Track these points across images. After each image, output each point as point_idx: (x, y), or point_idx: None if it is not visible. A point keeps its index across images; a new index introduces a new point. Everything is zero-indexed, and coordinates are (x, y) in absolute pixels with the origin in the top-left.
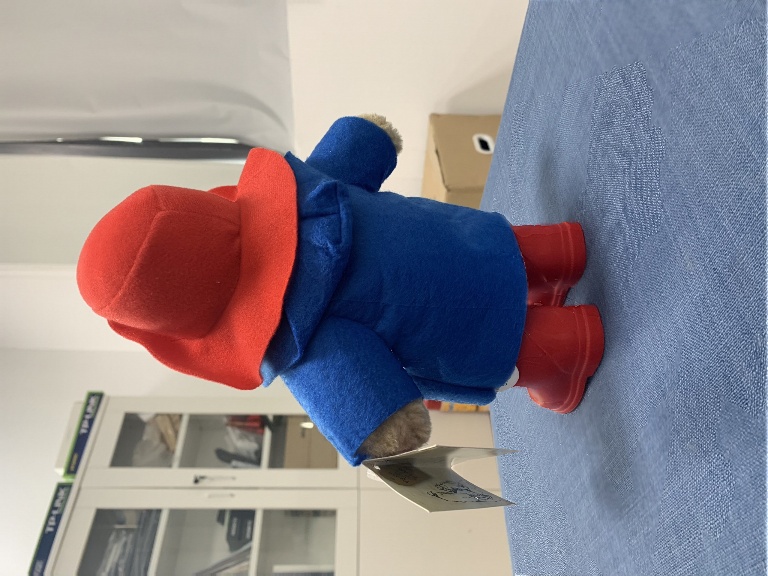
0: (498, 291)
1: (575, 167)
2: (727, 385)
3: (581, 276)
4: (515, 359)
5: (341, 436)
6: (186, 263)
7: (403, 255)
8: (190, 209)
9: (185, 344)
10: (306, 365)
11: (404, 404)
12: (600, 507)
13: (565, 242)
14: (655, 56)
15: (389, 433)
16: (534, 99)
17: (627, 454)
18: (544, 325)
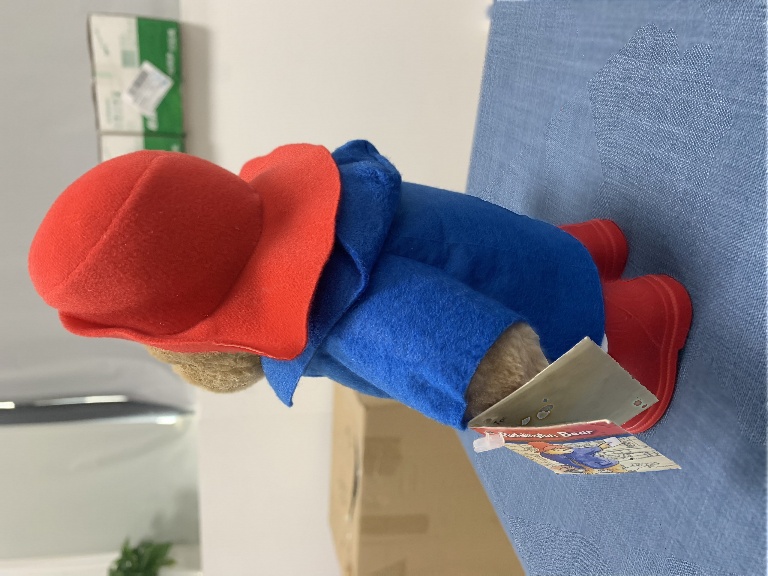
0: (561, 249)
1: (582, 175)
2: None
3: (624, 265)
4: (602, 319)
5: (444, 366)
6: (199, 199)
7: (455, 204)
8: (197, 159)
9: (179, 337)
10: (373, 298)
11: (518, 318)
12: (761, 495)
13: (600, 230)
14: (666, 1)
15: (508, 355)
16: (504, 170)
17: None
18: (616, 291)
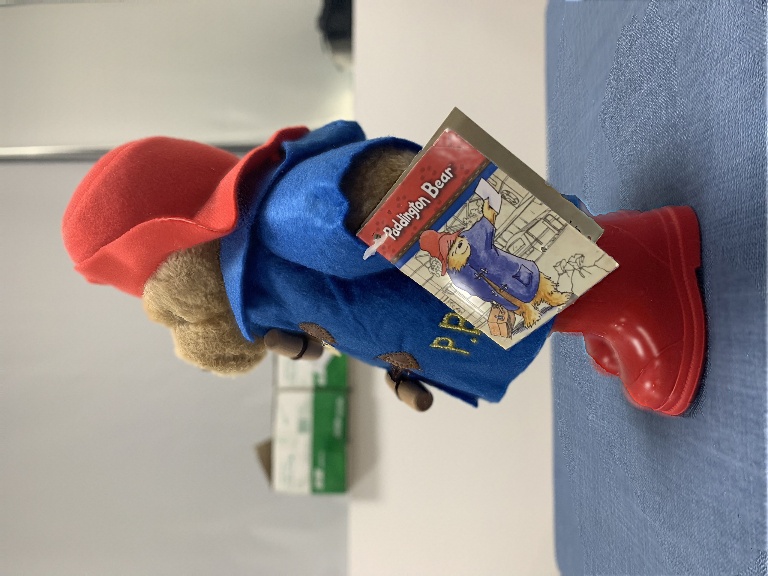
0: None
1: (608, 193)
2: None
3: None
4: None
5: (325, 169)
6: (185, 149)
7: None
8: None
9: None
10: (293, 168)
11: None
12: None
13: None
14: (625, 2)
15: (393, 158)
16: None
17: None
18: None
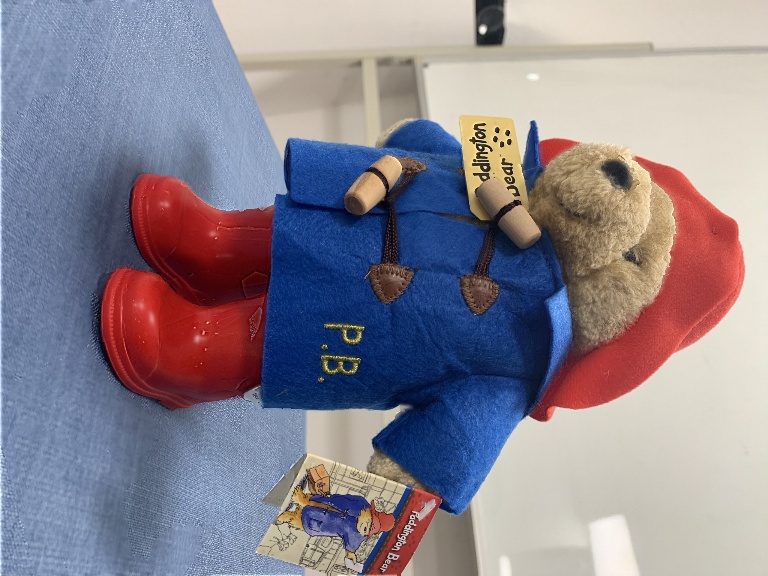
0: None
1: None
2: (229, 573)
3: None
4: None
5: None
6: None
7: None
8: None
9: None
10: None
11: None
12: None
13: None
14: None
15: None
16: None
17: (158, 524)
18: None
